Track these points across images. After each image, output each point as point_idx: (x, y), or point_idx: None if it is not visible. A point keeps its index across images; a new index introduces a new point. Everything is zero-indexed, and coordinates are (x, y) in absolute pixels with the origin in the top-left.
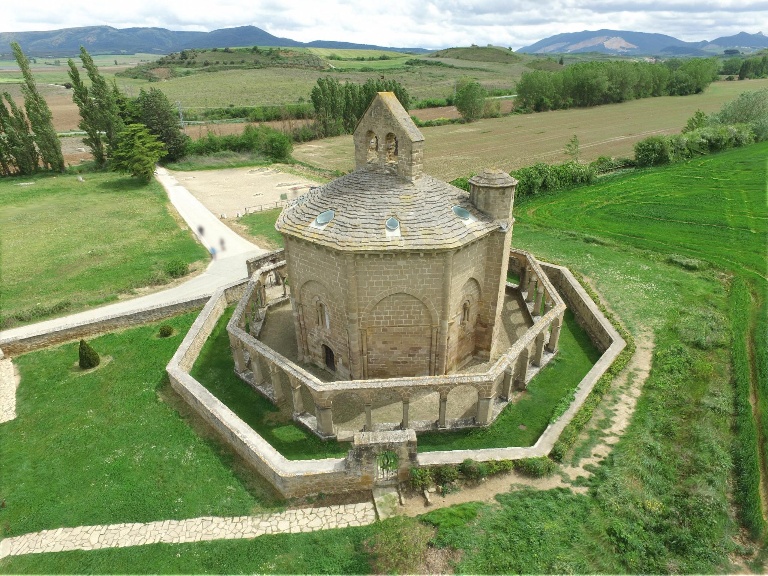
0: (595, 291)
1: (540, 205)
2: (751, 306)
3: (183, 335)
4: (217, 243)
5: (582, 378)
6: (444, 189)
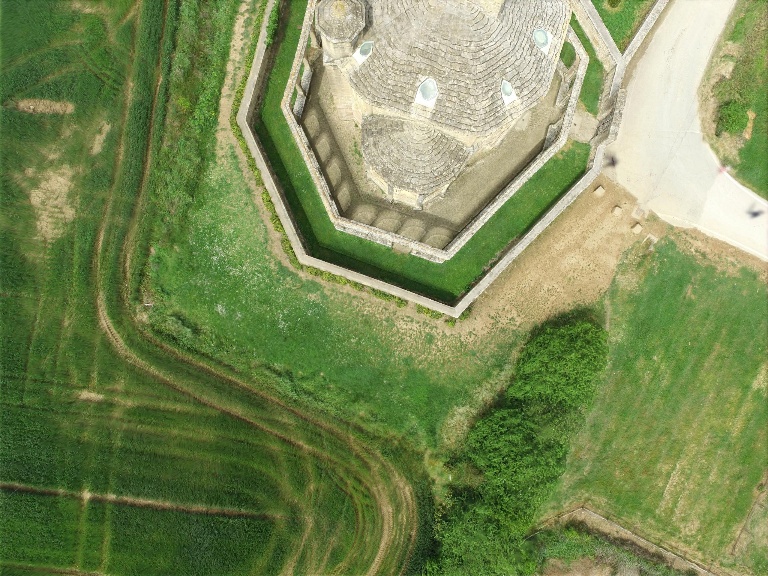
0: (267, 223)
1: (381, 568)
2: (133, 232)
3: (597, 6)
4: (767, 219)
5: (269, 98)
6: (388, 4)
